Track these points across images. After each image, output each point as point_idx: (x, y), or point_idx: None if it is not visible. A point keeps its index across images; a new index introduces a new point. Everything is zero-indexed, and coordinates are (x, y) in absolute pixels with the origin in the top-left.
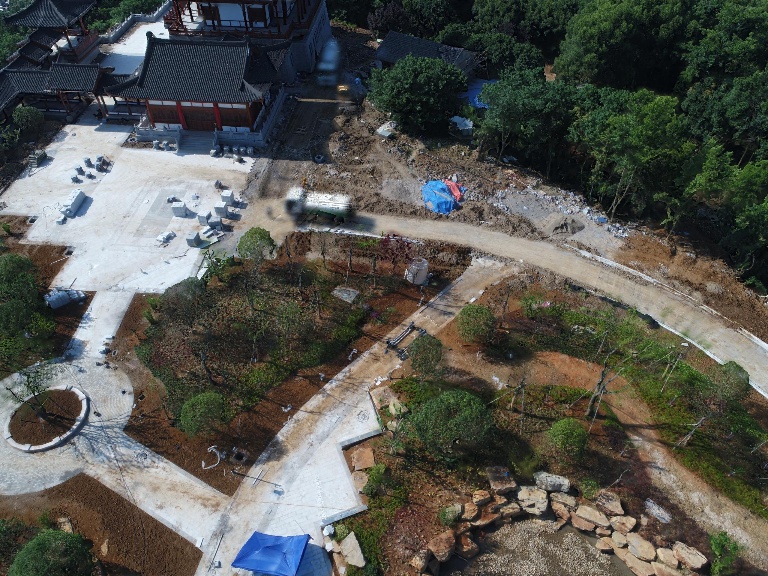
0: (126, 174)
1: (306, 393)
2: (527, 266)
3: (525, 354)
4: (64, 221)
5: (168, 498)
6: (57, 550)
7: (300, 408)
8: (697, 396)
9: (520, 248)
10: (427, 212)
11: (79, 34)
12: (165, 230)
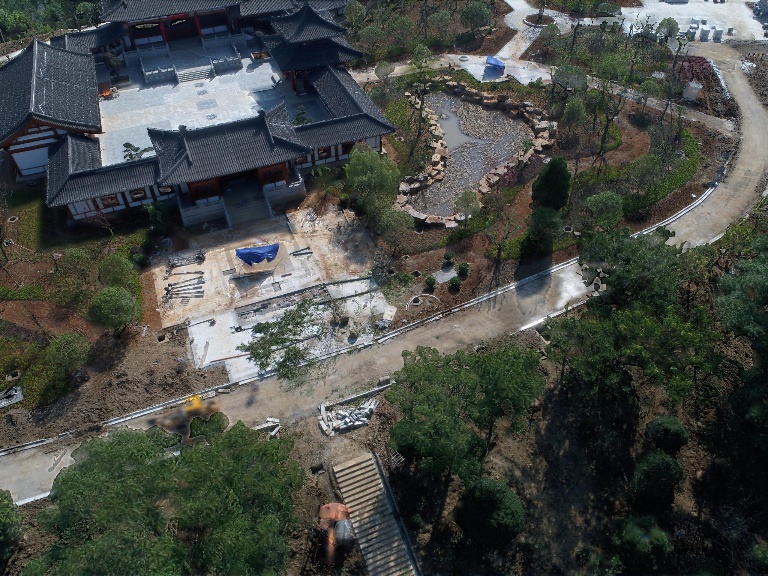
0: (718, 8)
1: None
2: (736, 138)
3: (642, 128)
4: (662, 1)
5: None
6: (480, 7)
7: None
8: None
9: (758, 138)
10: (767, 99)
11: None
12: None
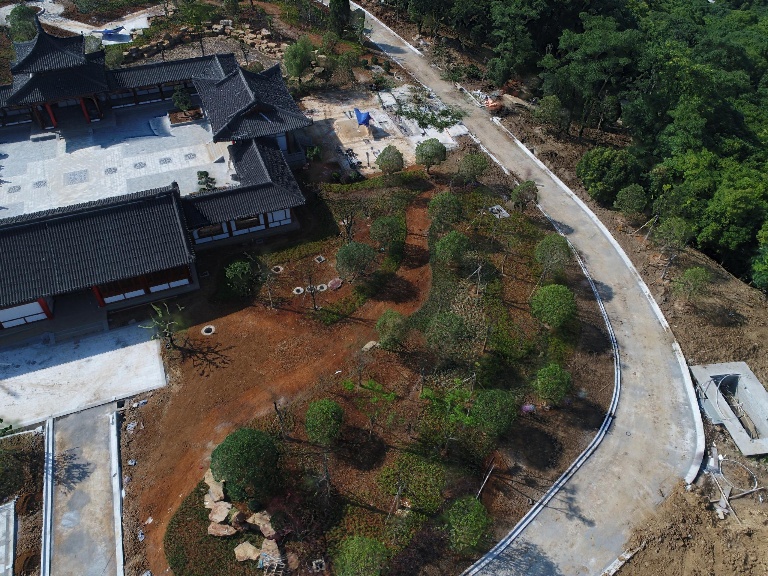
0: None
1: (139, 9)
2: None
3: None
4: None
5: (73, 27)
6: None
7: (135, 12)
8: (304, 8)
9: None
10: None
11: None
12: None
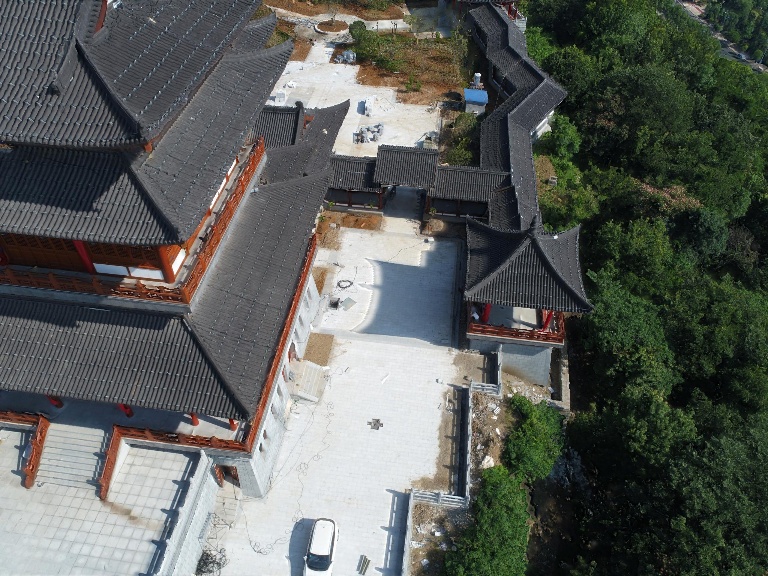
0: None
1: None
2: None
3: None
4: None
5: None
6: None
7: None
8: None
9: None
10: None
11: (508, 334)
12: (292, 90)
